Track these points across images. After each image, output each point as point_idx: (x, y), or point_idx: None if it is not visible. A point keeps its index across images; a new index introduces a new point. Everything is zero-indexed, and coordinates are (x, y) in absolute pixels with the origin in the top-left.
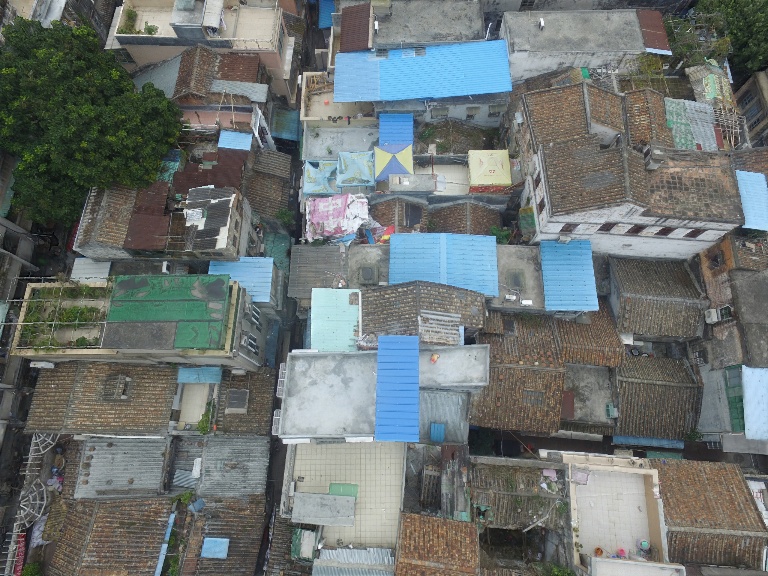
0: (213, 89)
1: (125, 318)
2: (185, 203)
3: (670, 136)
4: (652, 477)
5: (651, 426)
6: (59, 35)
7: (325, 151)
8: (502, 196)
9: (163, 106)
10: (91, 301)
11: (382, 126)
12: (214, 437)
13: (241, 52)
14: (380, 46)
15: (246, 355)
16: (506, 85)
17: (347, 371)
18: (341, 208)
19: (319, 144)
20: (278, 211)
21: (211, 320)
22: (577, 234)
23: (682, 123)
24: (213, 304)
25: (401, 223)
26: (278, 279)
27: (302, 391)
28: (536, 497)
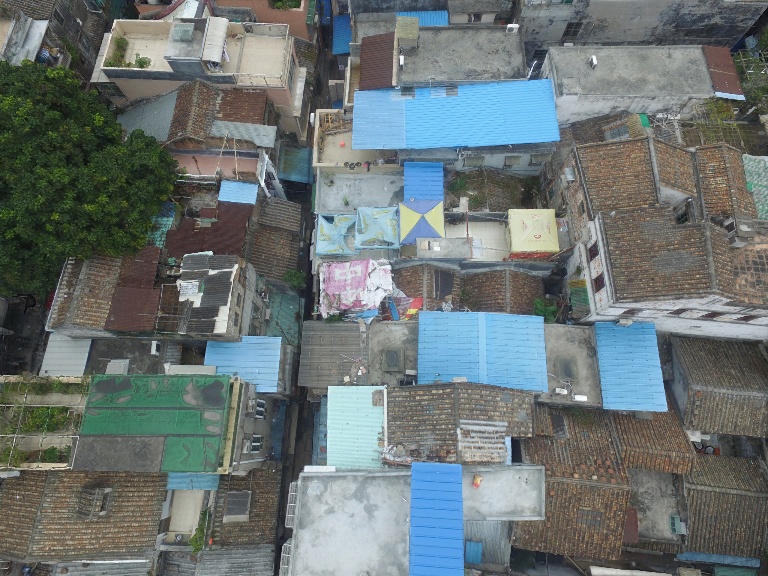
0: (213, 132)
1: (102, 431)
2: (179, 270)
3: (752, 203)
4: None
5: (723, 541)
6: (30, 79)
7: (341, 202)
8: (547, 263)
9: (153, 162)
10: (64, 397)
11: (407, 177)
12: None
13: (246, 88)
14: (406, 84)
15: (248, 458)
16: (553, 134)
17: (371, 496)
18: (361, 277)
19: (334, 193)
20: (286, 270)
21: (207, 435)
22: (640, 317)
23: (764, 185)
24: (209, 414)
25: (430, 295)
26: (286, 356)
27: (316, 521)
28: None
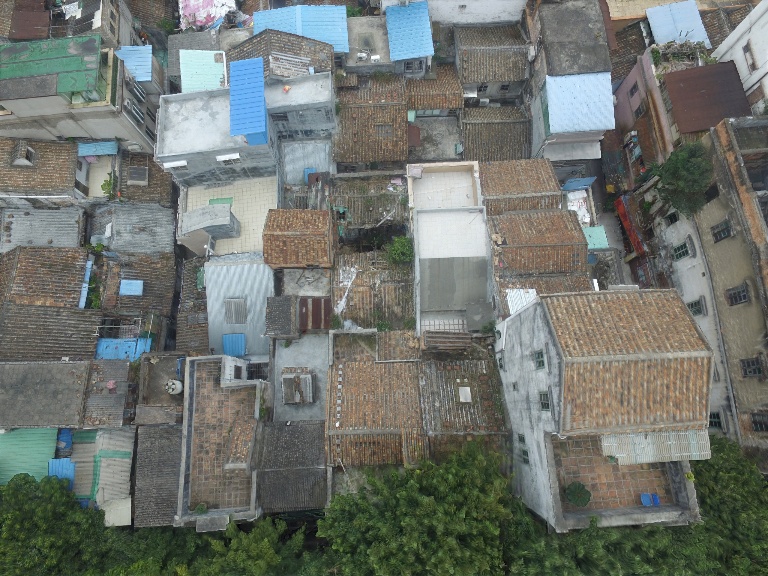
0: None
1: (11, 76)
2: None
3: None
4: (473, 166)
5: None
6: None
7: None
8: None
9: None
10: None
11: None
12: (121, 207)
13: None
14: None
15: (135, 125)
16: None
17: (213, 107)
18: None
19: None
20: None
21: (87, 70)
22: None
23: None
24: (88, 58)
25: None
26: (164, 75)
27: (176, 126)
28: (382, 194)
